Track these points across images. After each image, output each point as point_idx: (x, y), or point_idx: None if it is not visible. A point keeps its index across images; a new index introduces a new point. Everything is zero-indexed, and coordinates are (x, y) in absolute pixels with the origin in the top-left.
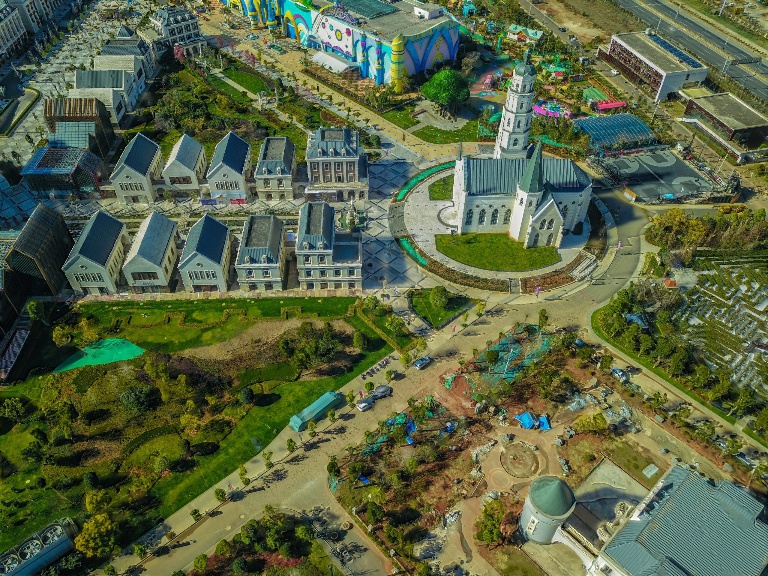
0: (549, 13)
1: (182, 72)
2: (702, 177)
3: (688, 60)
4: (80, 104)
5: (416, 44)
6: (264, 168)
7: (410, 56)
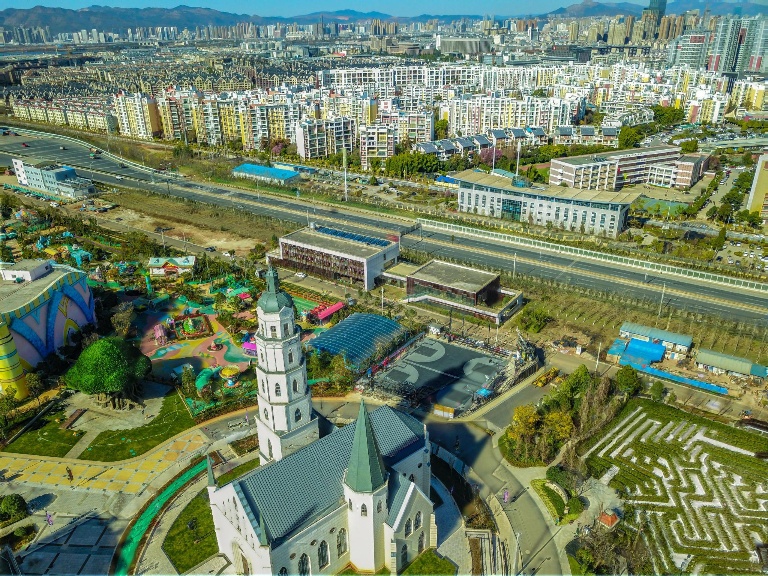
0: None
1: None
2: (484, 354)
3: (373, 241)
4: None
5: (28, 319)
6: None
7: (24, 339)
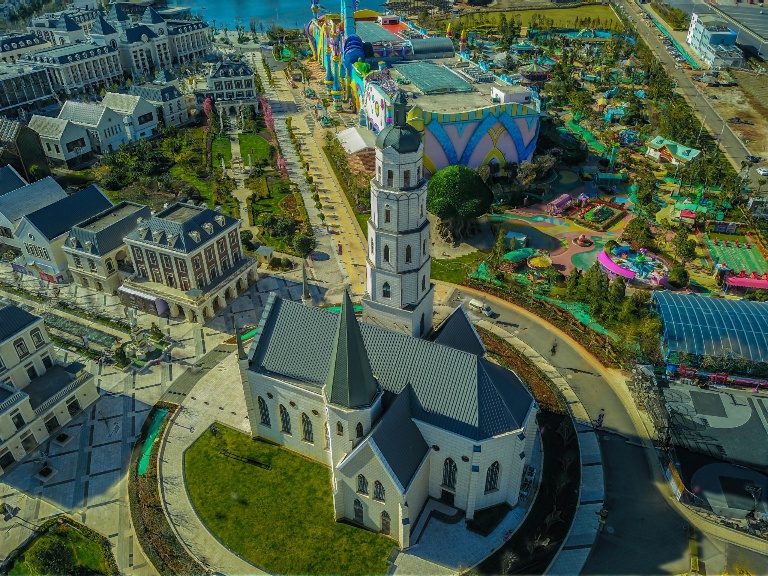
0: (746, 136)
1: (202, 127)
2: None
3: None
4: (5, 126)
5: (451, 128)
6: (71, 238)
7: (439, 144)
